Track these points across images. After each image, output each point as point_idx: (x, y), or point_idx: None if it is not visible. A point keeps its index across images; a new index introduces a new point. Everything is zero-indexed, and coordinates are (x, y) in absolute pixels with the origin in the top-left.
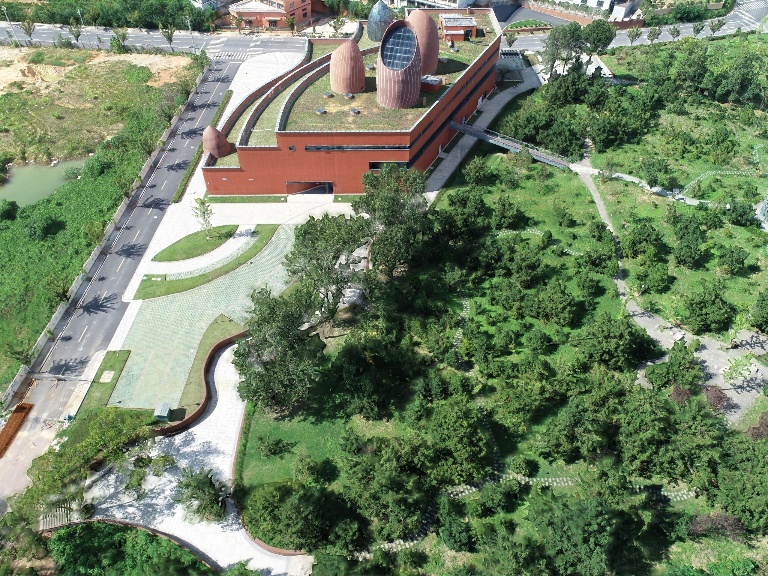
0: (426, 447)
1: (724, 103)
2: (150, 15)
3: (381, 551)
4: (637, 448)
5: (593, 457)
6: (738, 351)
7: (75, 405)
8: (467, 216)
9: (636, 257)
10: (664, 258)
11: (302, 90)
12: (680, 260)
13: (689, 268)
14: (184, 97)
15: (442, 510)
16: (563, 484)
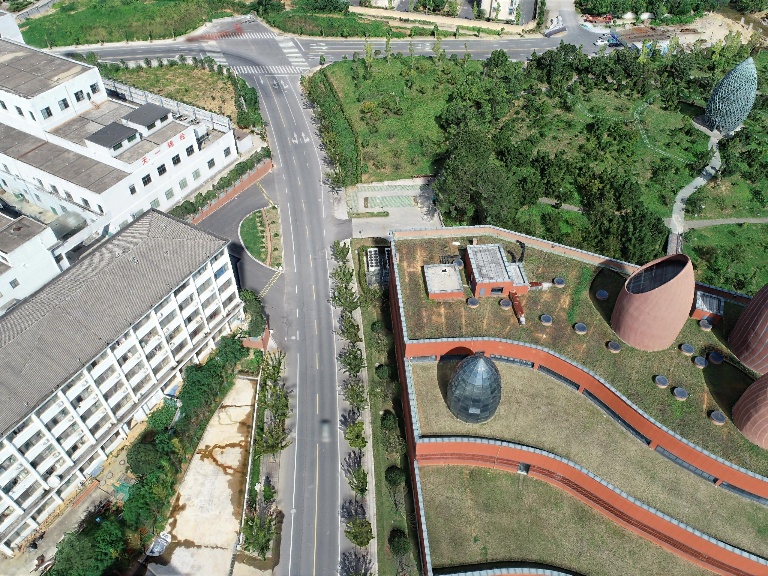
0: None
1: None
2: None
3: None
4: None
5: None
6: None
7: None
8: None
9: None
10: None
11: None
12: None
13: None
14: None
15: None
16: None
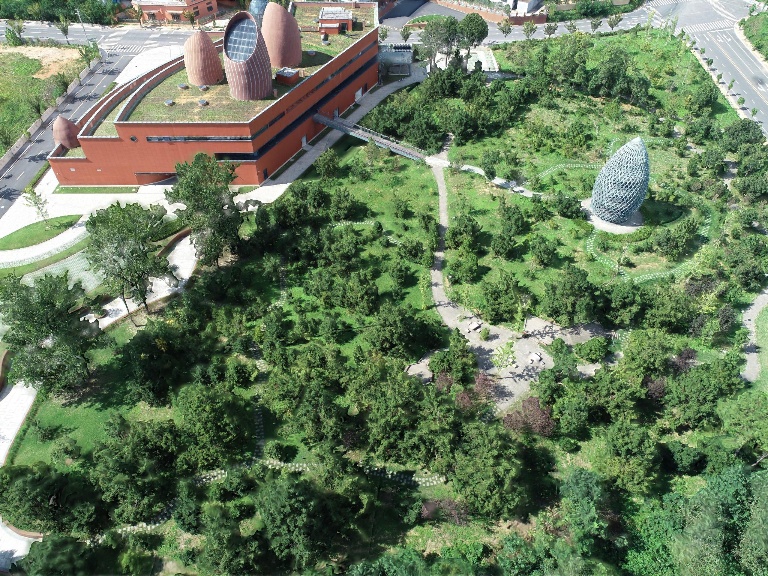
0: (173, 432)
1: (597, 97)
2: (52, 8)
3: (110, 533)
4: (382, 434)
5: (354, 443)
6: (528, 340)
7: None
8: (299, 207)
9: (459, 248)
10: (483, 249)
11: (159, 82)
12: (497, 251)
13: (506, 259)
14: (61, 89)
15: (181, 493)
16: None
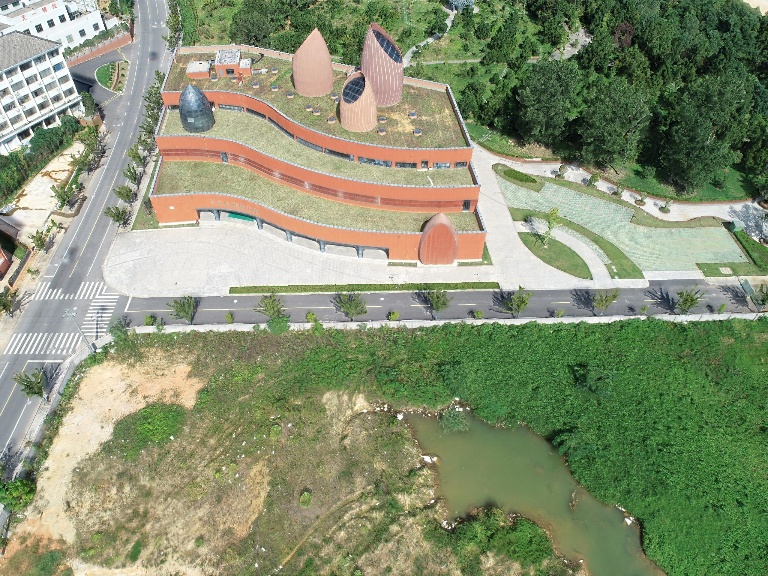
0: None
1: (309, 7)
2: None
3: (758, 128)
4: None
5: None
6: None
7: (762, 278)
8: None
9: None
10: None
11: None
12: None
13: None
14: None
15: None
16: (679, 87)
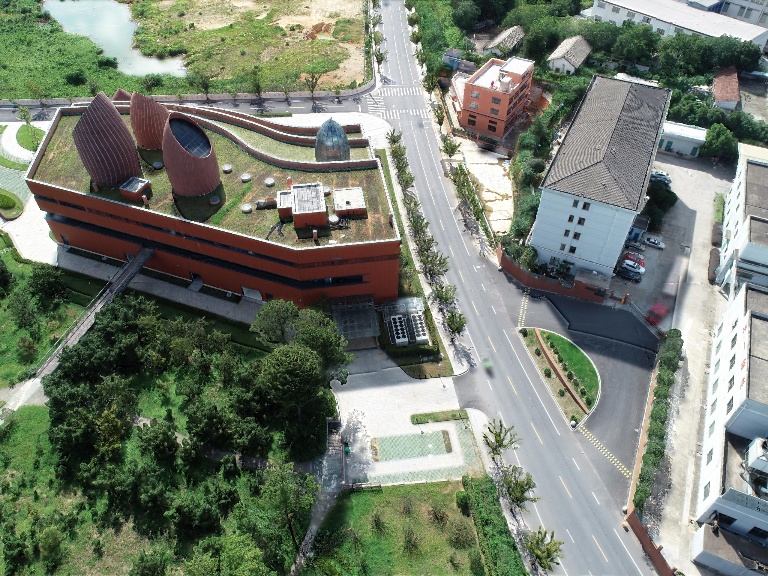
0: None
1: None
2: None
3: None
4: None
5: None
6: None
7: None
8: None
9: None
10: None
11: None
12: None
13: None
14: (253, 89)
15: None
16: None
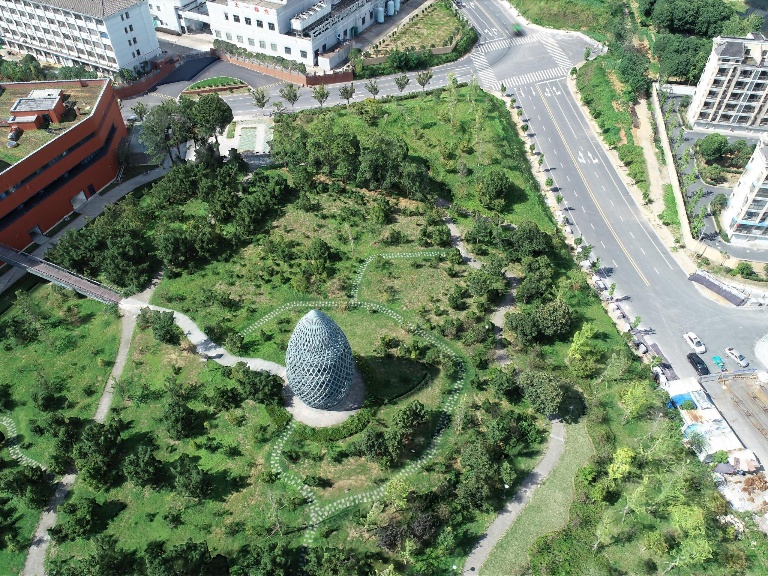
0: None
1: (371, 191)
2: None
3: None
4: None
5: None
6: None
7: None
8: None
9: None
10: (123, 472)
11: None
12: None
13: (152, 487)
14: None
15: None
16: None
